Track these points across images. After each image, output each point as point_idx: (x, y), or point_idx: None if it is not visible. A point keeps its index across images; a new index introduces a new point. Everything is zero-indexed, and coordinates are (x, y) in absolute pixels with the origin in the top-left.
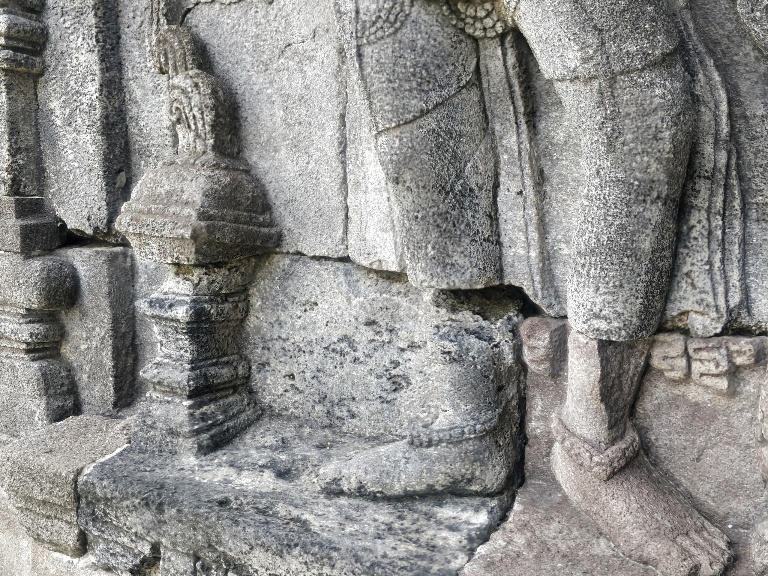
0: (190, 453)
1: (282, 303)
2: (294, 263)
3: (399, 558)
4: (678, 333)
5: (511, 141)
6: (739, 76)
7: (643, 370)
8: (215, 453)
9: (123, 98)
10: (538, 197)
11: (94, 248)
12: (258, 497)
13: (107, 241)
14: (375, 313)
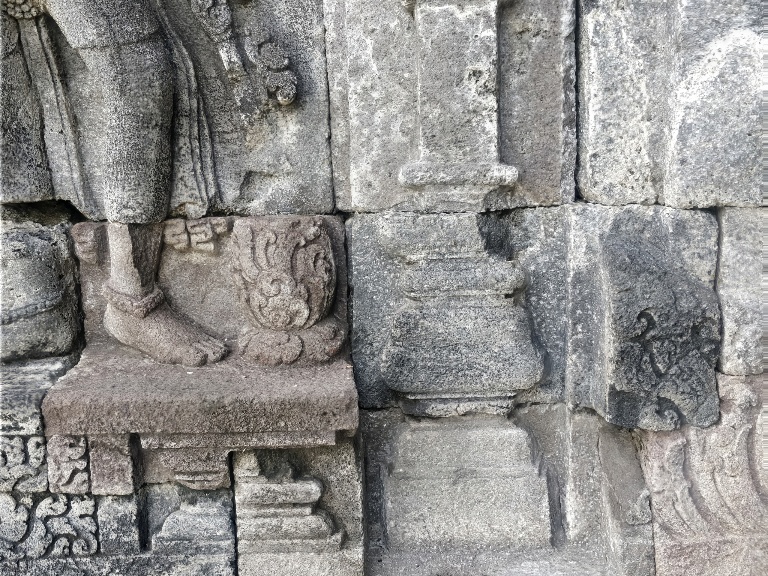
0: None
1: None
2: None
3: None
4: (180, 219)
5: (50, 94)
6: (199, 52)
7: (161, 247)
8: None
9: None
10: (75, 135)
11: None
12: None
13: None
14: None
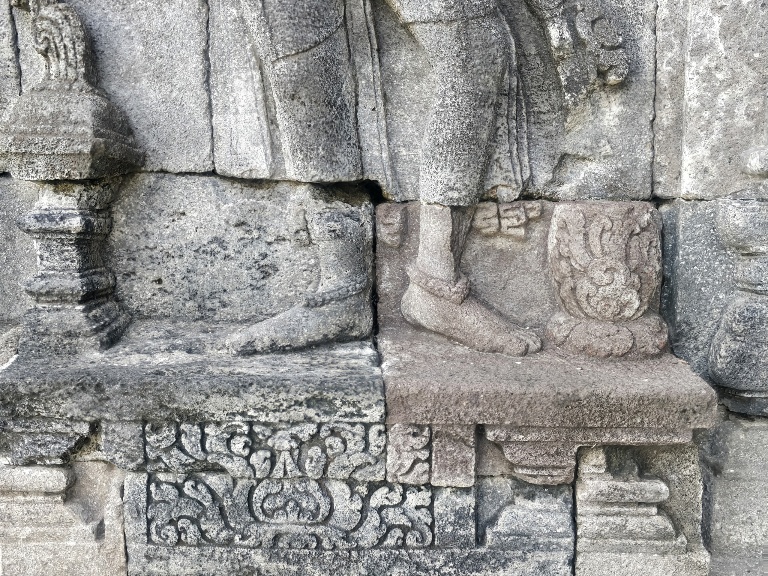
0: (93, 350)
1: (149, 216)
2: (160, 180)
3: (337, 376)
4: (491, 202)
5: (368, 70)
6: (519, 28)
7: None
8: (114, 348)
9: None
10: (384, 113)
11: None
12: (186, 366)
13: None
14: (245, 215)
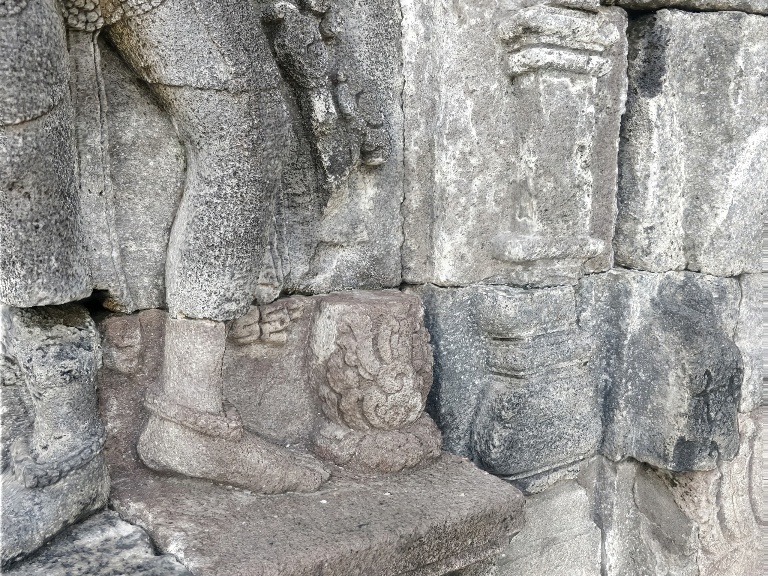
0: None
1: None
2: None
3: None
4: None
5: (96, 141)
6: None
7: None
8: None
9: None
10: None
11: None
12: None
13: None
14: None
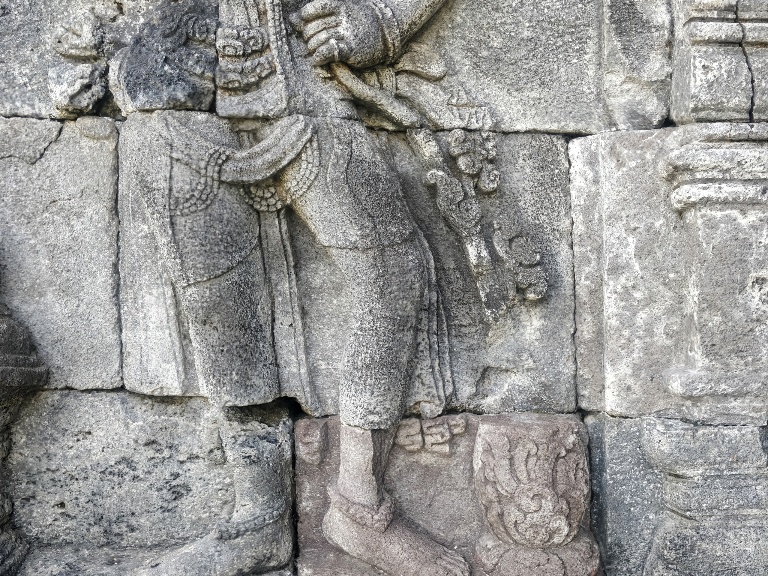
0: None
1: (51, 437)
2: (64, 398)
3: None
4: (414, 418)
5: (284, 287)
6: (437, 243)
7: (391, 448)
8: None
9: None
10: (302, 328)
11: None
12: None
13: None
14: (155, 434)
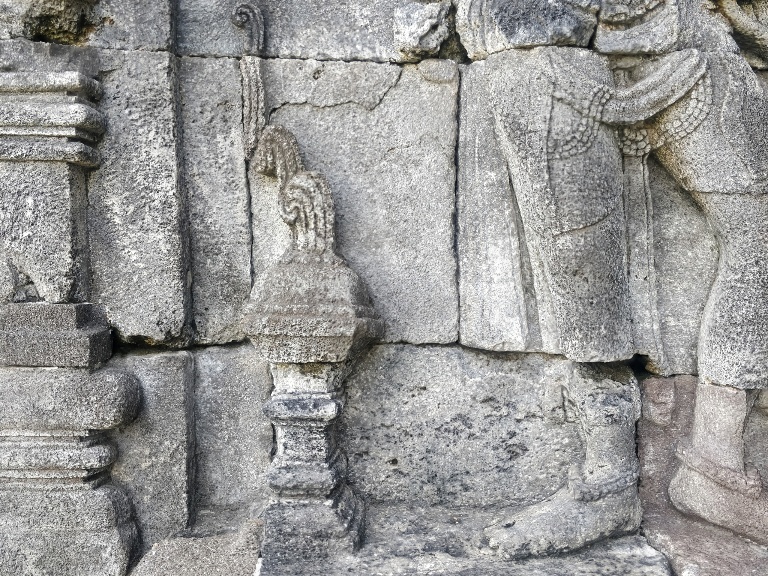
0: (346, 552)
1: (387, 391)
2: (400, 352)
3: None
4: None
5: (642, 238)
6: None
7: None
8: (365, 548)
9: (186, 194)
10: None
11: (152, 355)
12: None
13: (156, 346)
14: (493, 391)
